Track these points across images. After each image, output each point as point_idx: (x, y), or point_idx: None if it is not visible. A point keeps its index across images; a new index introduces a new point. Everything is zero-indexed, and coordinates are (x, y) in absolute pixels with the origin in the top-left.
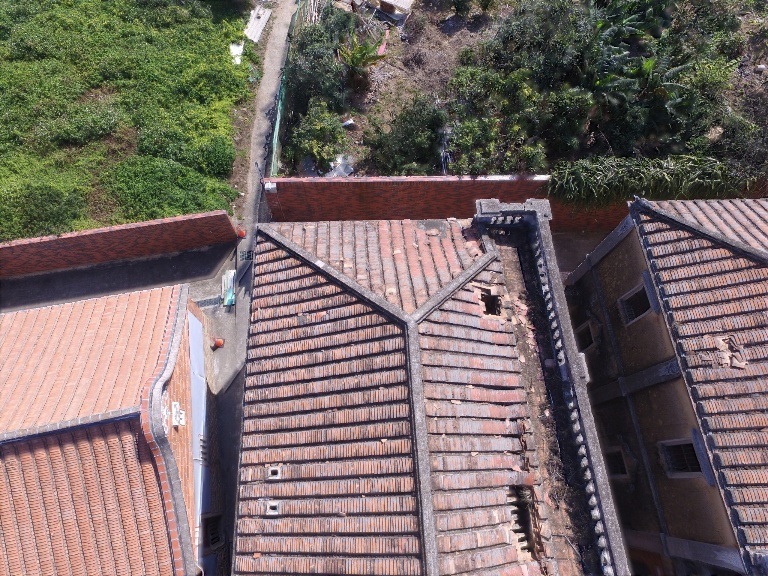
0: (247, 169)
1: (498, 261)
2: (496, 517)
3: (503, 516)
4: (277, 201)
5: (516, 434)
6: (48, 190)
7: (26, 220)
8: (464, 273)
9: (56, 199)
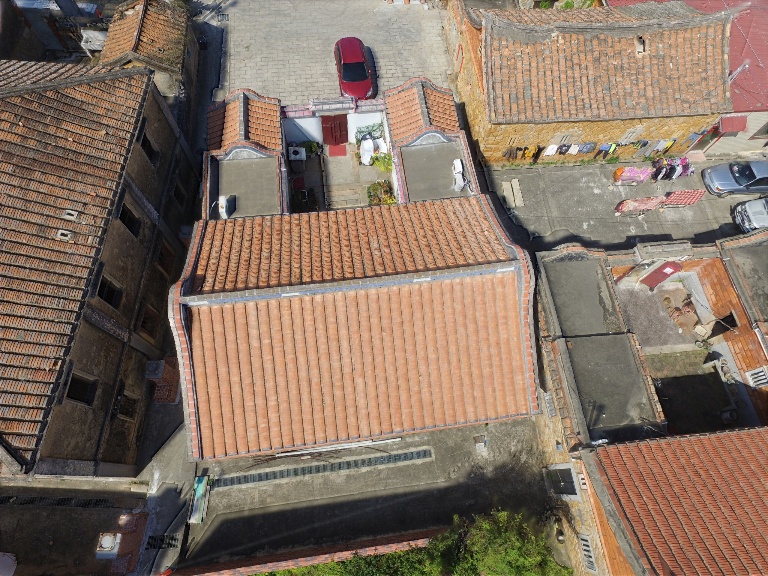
0: None
1: None
2: None
3: None
4: None
5: None
6: None
7: None
8: None
9: None
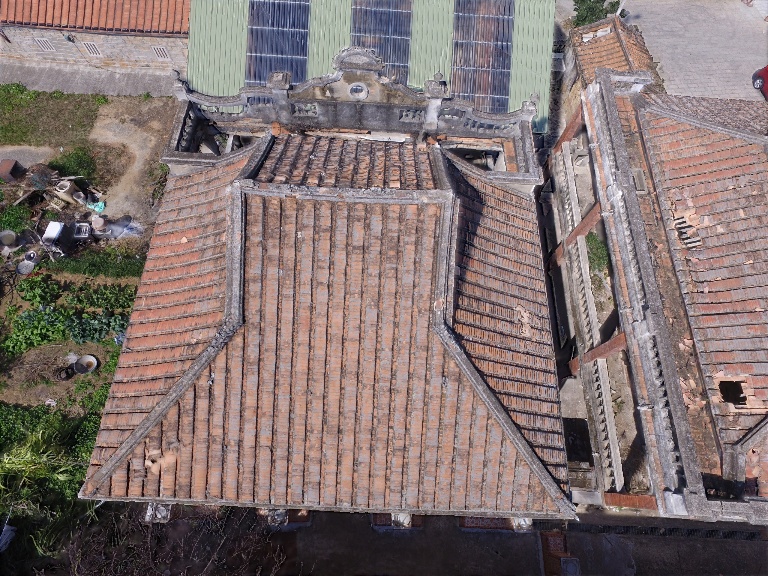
0: None
1: (728, 444)
2: (720, 228)
3: (710, 230)
4: None
5: (696, 282)
6: None
7: None
8: None
9: None
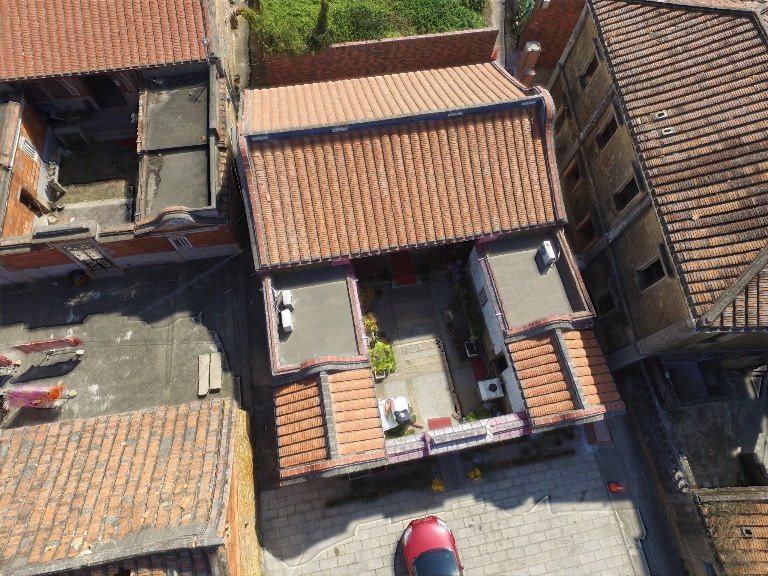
0: (491, 11)
1: None
2: None
3: None
4: (538, 21)
5: None
6: (365, 8)
7: (355, 27)
8: (767, 3)
9: (370, 16)
